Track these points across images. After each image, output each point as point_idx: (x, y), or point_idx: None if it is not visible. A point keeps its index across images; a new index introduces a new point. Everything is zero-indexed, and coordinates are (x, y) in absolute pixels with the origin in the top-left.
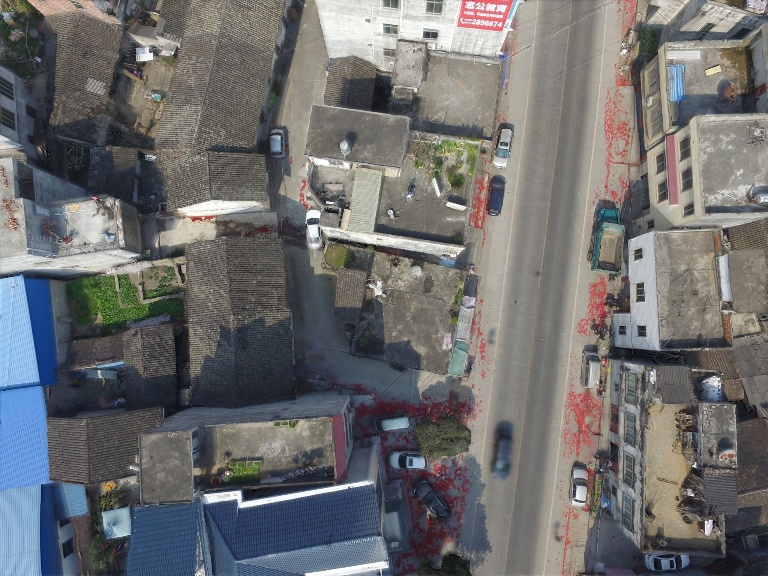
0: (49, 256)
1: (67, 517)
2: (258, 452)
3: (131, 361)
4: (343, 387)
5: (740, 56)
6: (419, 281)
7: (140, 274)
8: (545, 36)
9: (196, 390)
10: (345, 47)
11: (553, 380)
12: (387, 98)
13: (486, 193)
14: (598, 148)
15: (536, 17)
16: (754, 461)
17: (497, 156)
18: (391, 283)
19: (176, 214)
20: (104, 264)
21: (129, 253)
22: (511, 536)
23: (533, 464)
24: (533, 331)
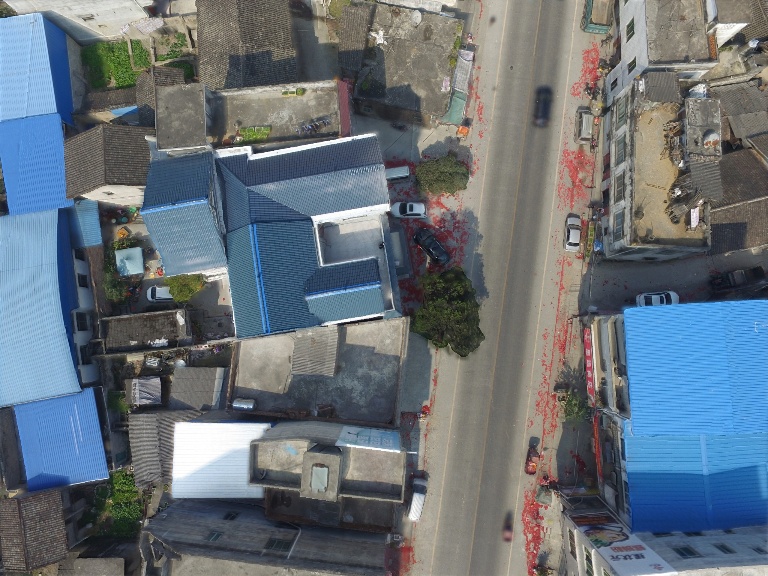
0: None
1: (82, 247)
2: (267, 121)
3: (144, 101)
4: None
5: None
6: (419, 30)
7: (152, 40)
8: None
9: None
10: None
11: (548, 139)
12: None
13: None
14: None
15: None
16: (739, 181)
17: None
18: (392, 32)
19: None
20: (118, 20)
21: None
22: (507, 282)
23: (529, 216)
24: (528, 94)
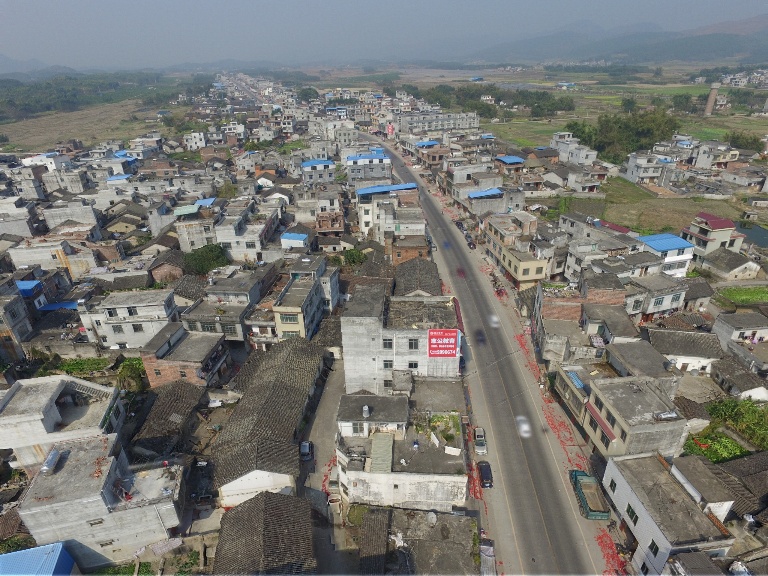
0: (109, 507)
1: None
2: None
3: None
4: None
5: (606, 366)
6: (436, 529)
7: (162, 561)
8: (487, 383)
9: None
10: (358, 383)
11: None
12: None
13: (477, 473)
14: (551, 438)
15: (478, 376)
16: None
17: (477, 446)
18: (410, 534)
19: (213, 503)
20: (136, 544)
21: (173, 515)
22: None
23: None
24: None
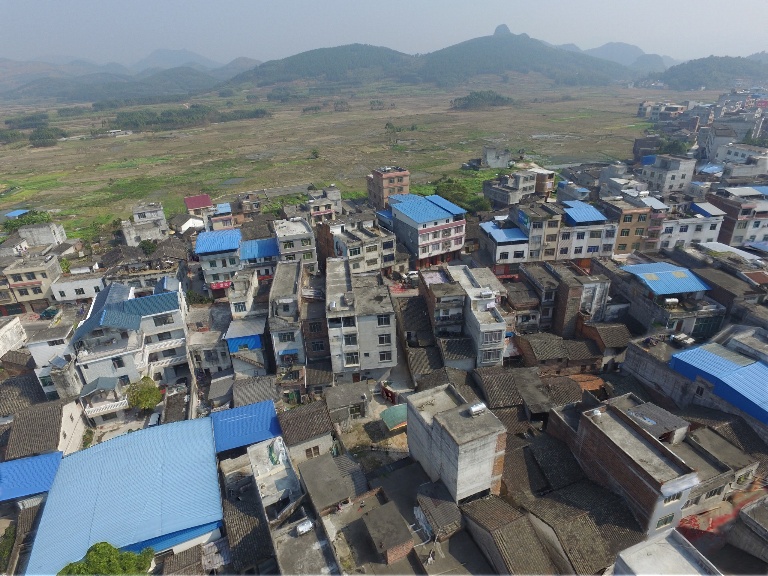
0: None
1: None
2: None
3: None
4: None
5: None
6: None
7: None
8: None
9: None
10: None
11: None
12: None
13: None
14: None
15: None
16: None
17: None
18: (27, 353)
19: None
20: None
21: None
22: None
23: None
24: None
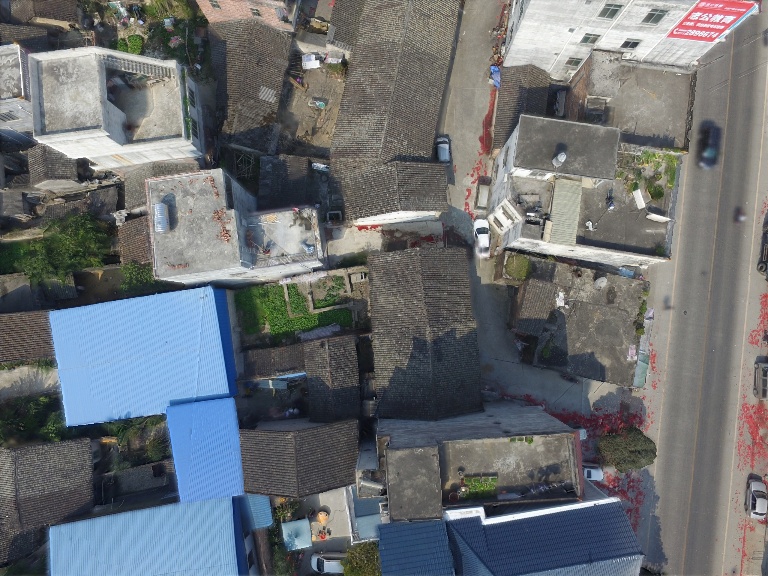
0: (251, 267)
1: None
2: (492, 468)
3: (315, 372)
4: (514, 398)
5: None
6: (602, 292)
7: (308, 283)
8: None
9: (383, 402)
10: (527, 56)
11: (726, 391)
12: (553, 106)
13: None
14: (765, 157)
15: None
16: None
17: None
18: (573, 294)
19: (345, 223)
20: (280, 274)
21: (318, 264)
22: (687, 548)
23: (707, 476)
24: (704, 342)
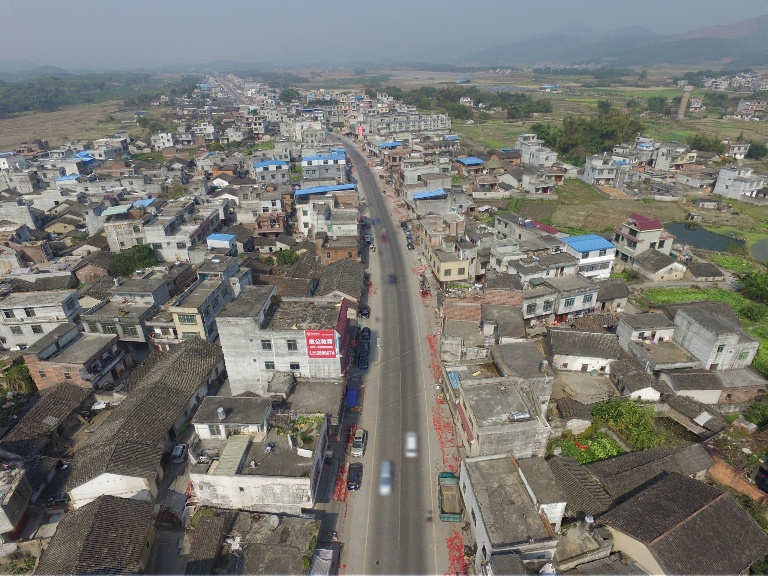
0: None
1: None
2: None
3: None
4: None
5: (491, 367)
6: (276, 533)
7: None
8: (385, 384)
9: None
10: (243, 384)
11: None
12: None
13: None
14: (432, 439)
15: (379, 377)
16: None
17: (354, 447)
18: (249, 537)
19: (66, 507)
20: None
21: (5, 520)
22: None
23: None
24: None
